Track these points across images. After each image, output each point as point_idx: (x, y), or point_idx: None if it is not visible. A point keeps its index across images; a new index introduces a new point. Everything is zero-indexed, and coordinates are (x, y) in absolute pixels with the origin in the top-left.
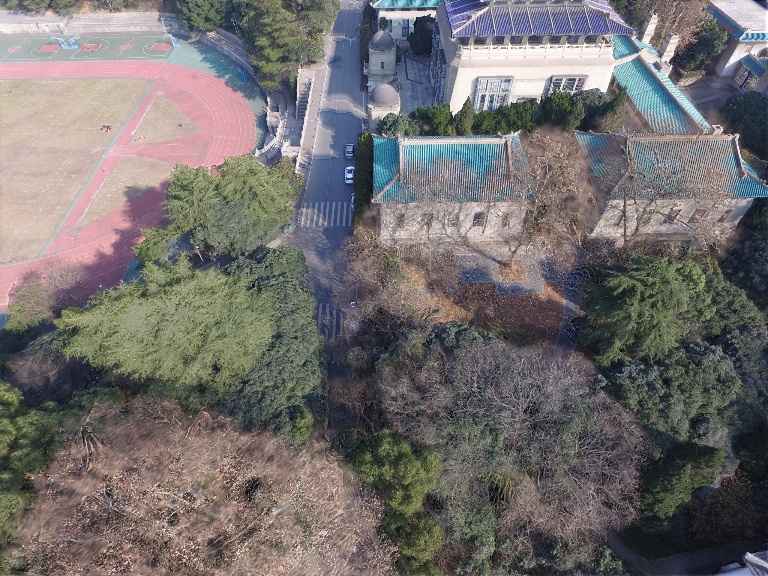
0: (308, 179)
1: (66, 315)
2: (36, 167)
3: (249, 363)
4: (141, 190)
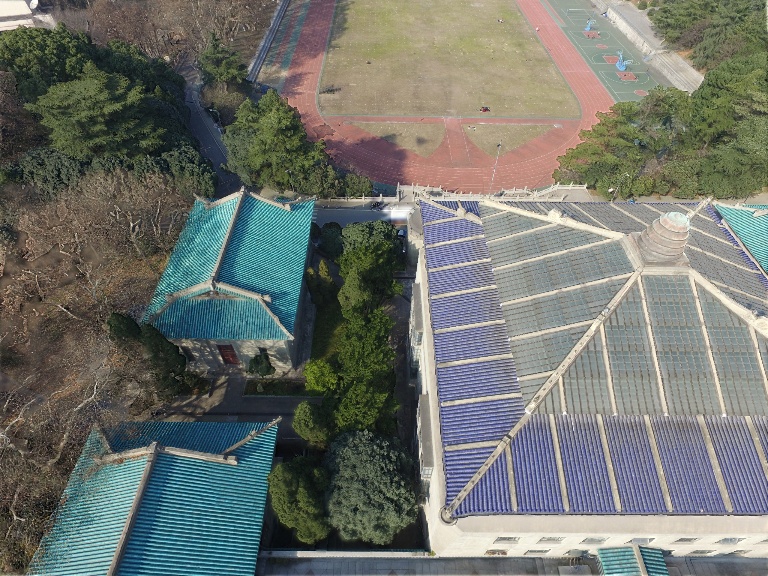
0: (355, 210)
1: (156, 88)
2: (425, 92)
3: (65, 150)
4: (396, 141)
